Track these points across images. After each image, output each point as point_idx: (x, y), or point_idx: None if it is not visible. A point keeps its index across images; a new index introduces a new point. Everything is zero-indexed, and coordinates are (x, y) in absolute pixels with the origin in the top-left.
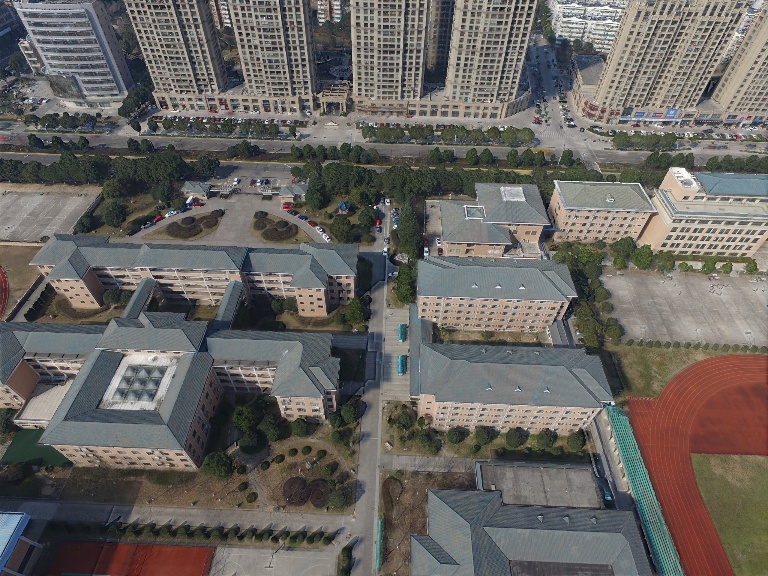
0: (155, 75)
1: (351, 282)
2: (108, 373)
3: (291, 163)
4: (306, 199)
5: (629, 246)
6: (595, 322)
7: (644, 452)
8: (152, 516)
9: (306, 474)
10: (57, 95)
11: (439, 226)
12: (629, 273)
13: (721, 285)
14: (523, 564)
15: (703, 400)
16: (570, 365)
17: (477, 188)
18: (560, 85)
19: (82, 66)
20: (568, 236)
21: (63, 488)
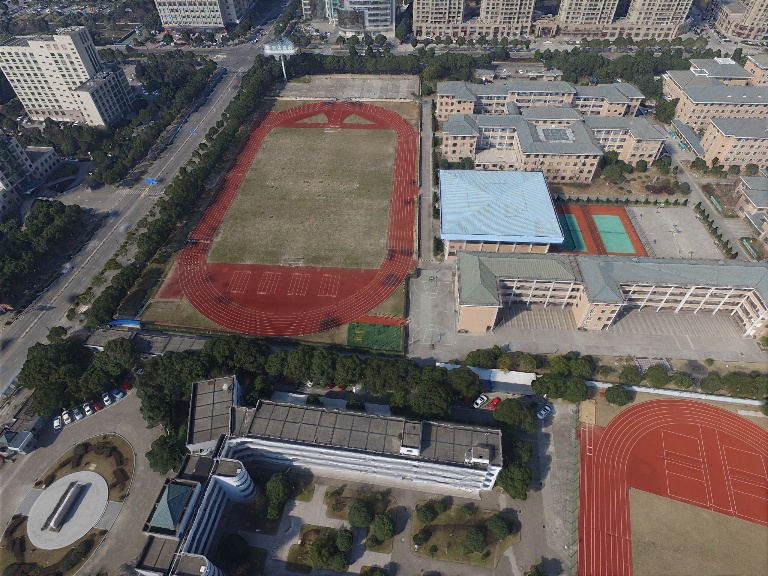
0: (419, 10)
1: (638, 104)
2: (535, 130)
3: (534, 63)
4: (564, 77)
5: None
6: None
7: None
8: None
9: (654, 184)
10: (343, 27)
11: (664, 90)
12: None
13: None
14: None
15: None
16: None
17: (694, 62)
18: None
19: (373, 3)
20: None
21: None
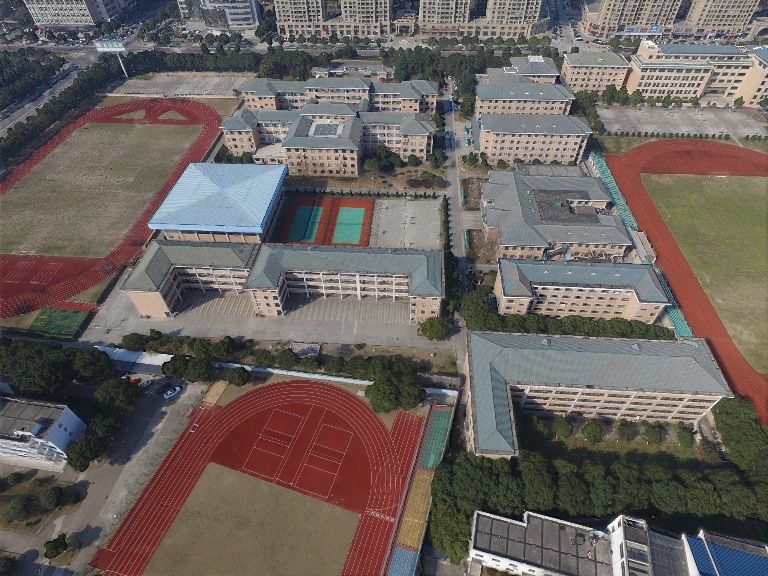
0: (279, 9)
1: (434, 101)
2: (308, 125)
3: (379, 61)
4: (395, 75)
5: (613, 89)
6: (587, 118)
7: (612, 172)
8: (338, 190)
9: (418, 178)
10: (209, 26)
11: None
12: (613, 108)
13: (674, 112)
14: (540, 191)
15: (652, 155)
16: (568, 116)
17: (512, 60)
18: (572, 18)
19: (232, 1)
20: (573, 90)
21: (287, 181)
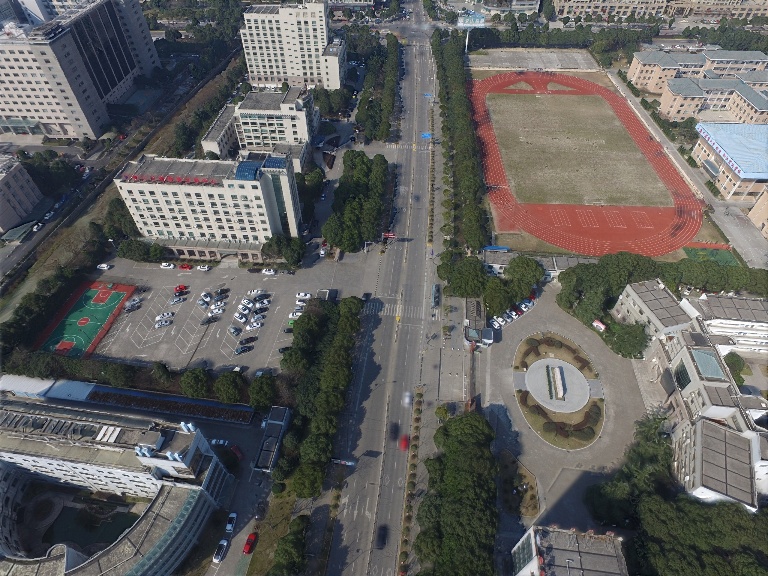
0: None
1: None
2: None
3: (683, 39)
4: None
5: None
6: None
7: None
8: None
9: None
10: (490, 6)
11: None
12: None
13: None
14: None
15: None
16: None
17: None
18: None
19: None
20: None
21: None
